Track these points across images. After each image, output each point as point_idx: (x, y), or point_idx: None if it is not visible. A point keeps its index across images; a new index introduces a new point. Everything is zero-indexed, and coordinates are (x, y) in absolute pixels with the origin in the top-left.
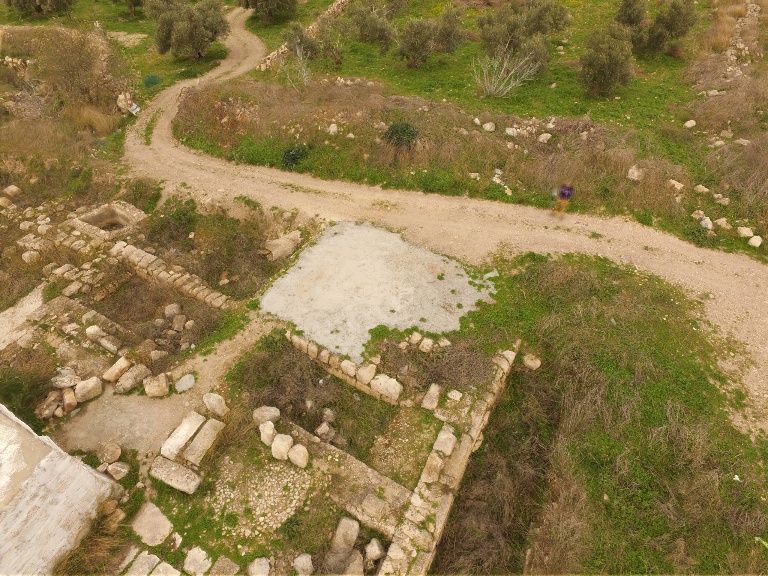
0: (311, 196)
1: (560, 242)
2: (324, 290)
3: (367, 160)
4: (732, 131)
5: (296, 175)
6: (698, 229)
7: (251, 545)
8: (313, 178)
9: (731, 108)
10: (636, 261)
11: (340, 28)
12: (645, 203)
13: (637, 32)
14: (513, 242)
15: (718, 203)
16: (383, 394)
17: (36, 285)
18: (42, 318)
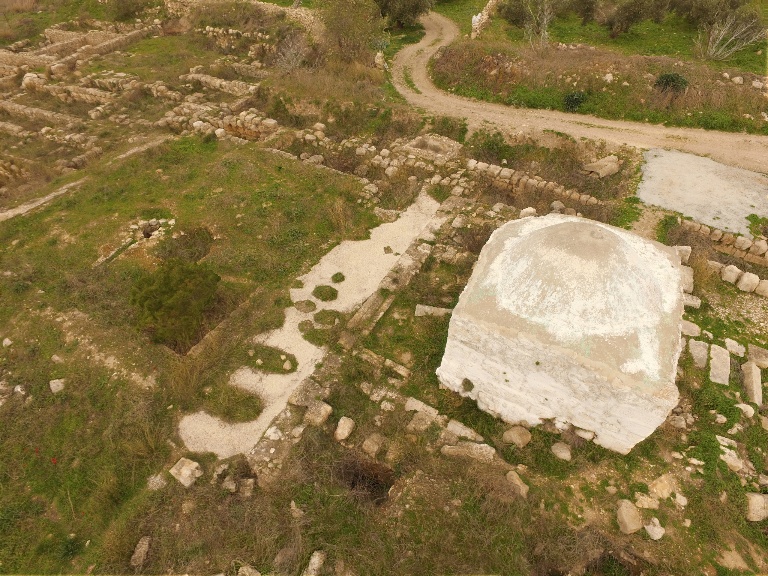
0: (608, 130)
1: None
2: (684, 192)
3: (645, 104)
4: None
5: (580, 116)
6: None
7: (764, 339)
8: (597, 118)
9: None
10: None
11: (540, 2)
12: None
13: None
14: None
15: None
16: None
17: (416, 190)
18: (453, 209)
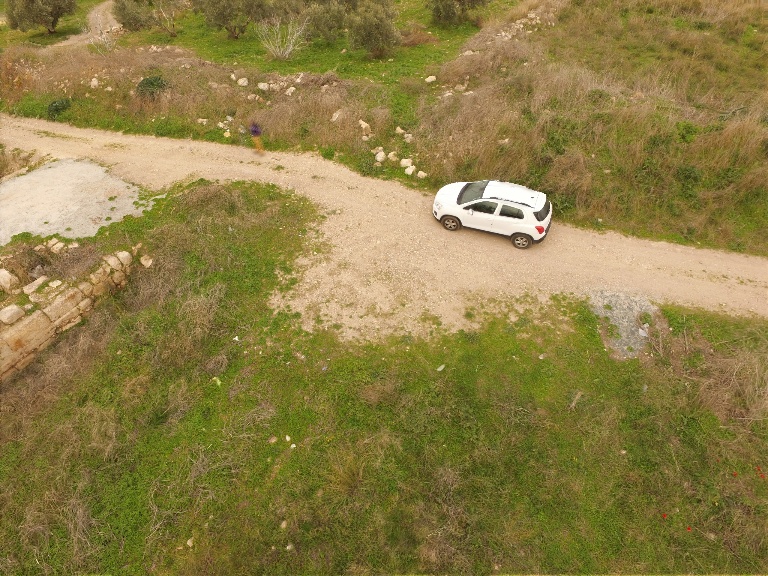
0: (55, 140)
1: (242, 173)
2: (0, 208)
3: (117, 110)
4: (468, 85)
5: (57, 124)
6: (367, 161)
7: None
8: (70, 126)
9: (470, 65)
10: (298, 187)
11: None
12: (330, 140)
13: (435, 3)
14: (201, 173)
15: (403, 141)
16: (1, 285)
17: None
18: None
